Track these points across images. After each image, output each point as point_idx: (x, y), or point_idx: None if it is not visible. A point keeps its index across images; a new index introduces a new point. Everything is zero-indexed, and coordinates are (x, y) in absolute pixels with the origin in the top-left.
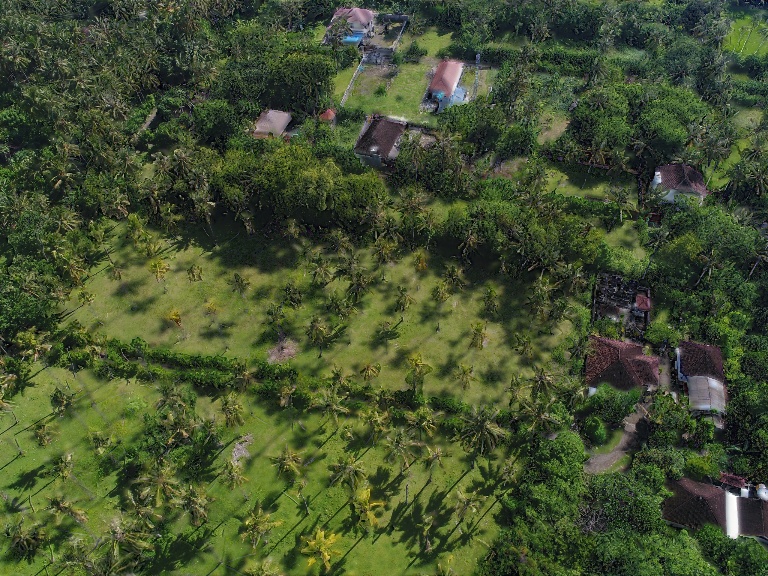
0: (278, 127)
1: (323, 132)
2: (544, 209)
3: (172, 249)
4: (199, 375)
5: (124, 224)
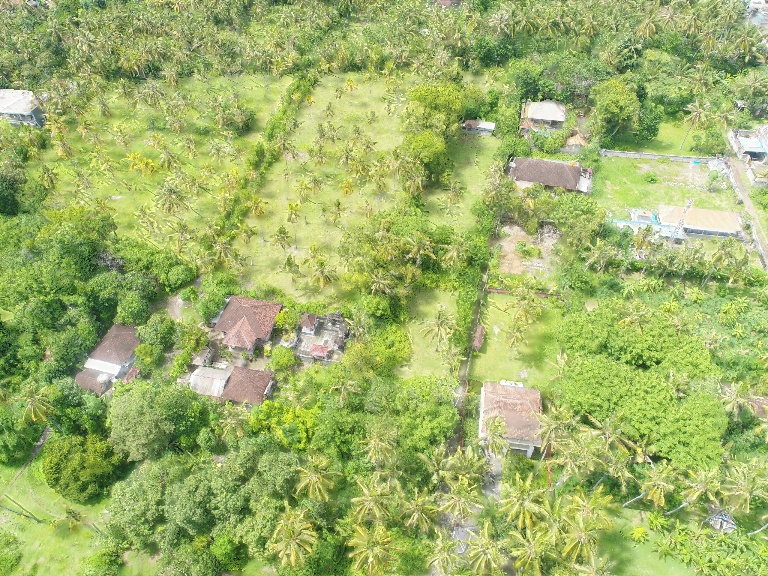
0: (540, 112)
1: (540, 136)
2: (418, 259)
3: (392, 98)
4: (271, 120)
5: (415, 76)
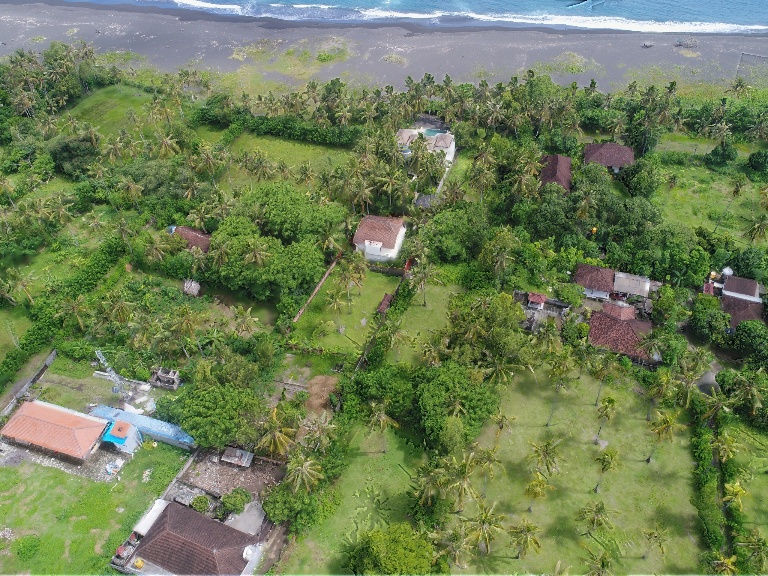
0: None
1: None
2: None
3: None
4: None
5: None
